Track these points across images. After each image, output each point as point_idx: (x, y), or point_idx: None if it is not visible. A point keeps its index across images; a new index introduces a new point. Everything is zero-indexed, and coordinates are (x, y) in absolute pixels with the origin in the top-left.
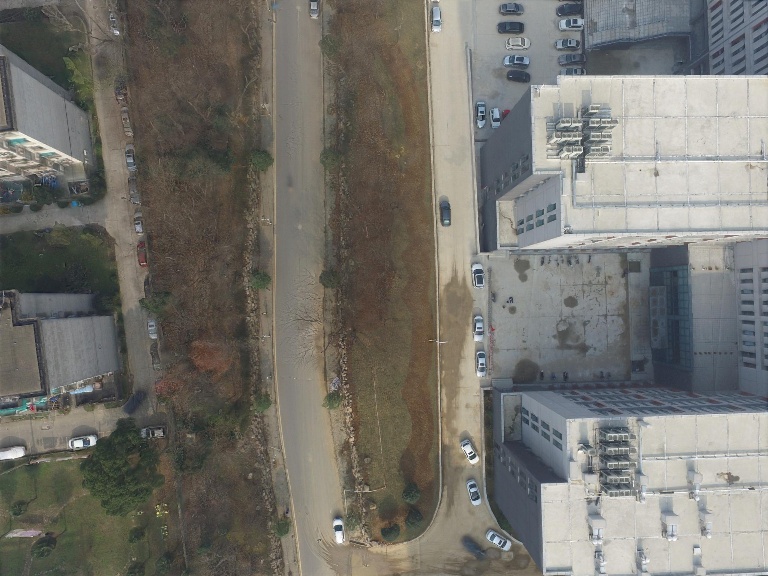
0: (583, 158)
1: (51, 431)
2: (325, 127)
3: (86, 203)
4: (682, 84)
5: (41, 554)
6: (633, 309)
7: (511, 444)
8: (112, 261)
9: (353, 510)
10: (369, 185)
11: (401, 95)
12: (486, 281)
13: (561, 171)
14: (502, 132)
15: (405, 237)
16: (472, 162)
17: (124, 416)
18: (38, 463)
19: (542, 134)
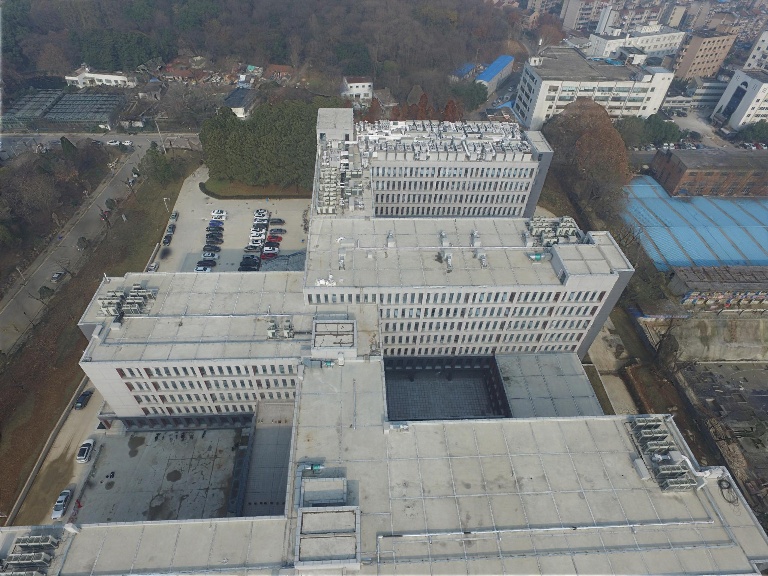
0: (122, 315)
1: None
2: (17, 342)
3: None
4: (217, 276)
5: None
6: None
7: None
8: None
9: None
10: (18, 375)
11: None
12: (94, 457)
13: None
14: None
15: (28, 415)
16: None
17: None
18: None
19: None
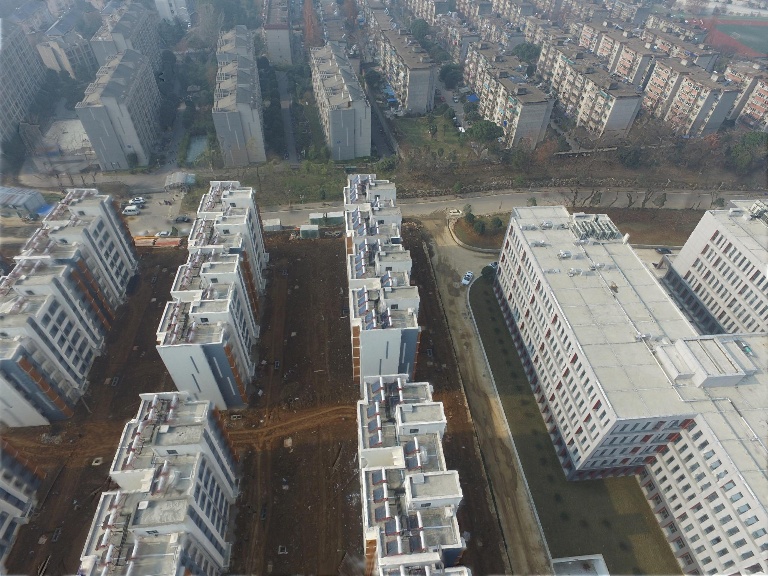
0: (759, 217)
1: None
2: None
3: None
4: None
5: (433, 127)
6: None
7: None
8: None
9: None
10: (658, 215)
11: None
12: None
13: None
14: None
15: (639, 229)
16: None
17: None
18: None
19: None
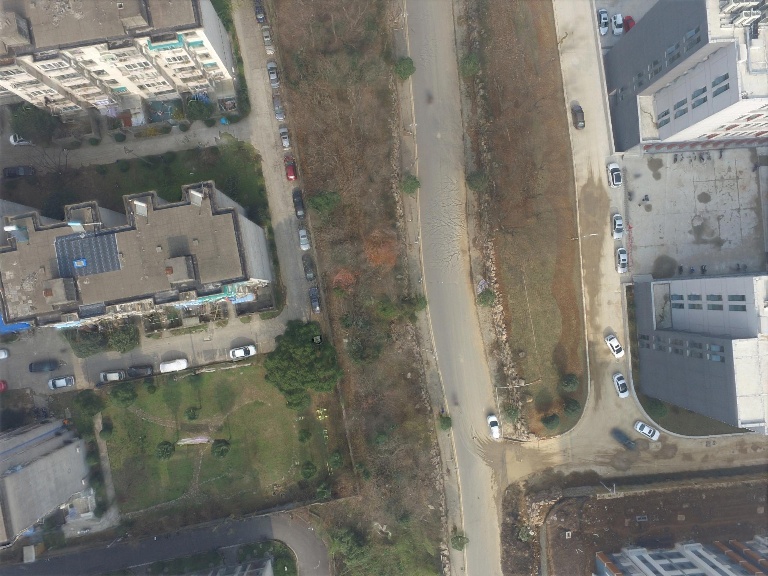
0: (756, 25)
1: (210, 344)
2: (457, 38)
3: (233, 121)
4: None
5: (221, 453)
6: (765, 202)
7: (664, 330)
8: (260, 176)
9: (505, 407)
10: (508, 89)
11: (530, 3)
12: None
13: (736, 38)
14: (647, 23)
15: (544, 139)
16: (600, 66)
17: (279, 326)
18: (201, 374)
19: (715, 4)
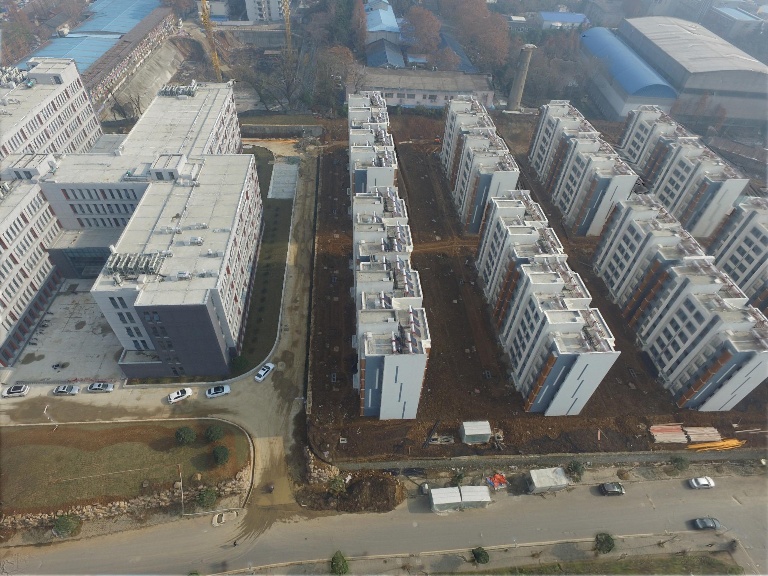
0: None
1: None
2: None
3: None
4: None
5: None
6: None
7: None
8: None
9: None
10: None
11: None
12: None
13: None
14: None
15: None
16: None
17: None
18: None
19: None
